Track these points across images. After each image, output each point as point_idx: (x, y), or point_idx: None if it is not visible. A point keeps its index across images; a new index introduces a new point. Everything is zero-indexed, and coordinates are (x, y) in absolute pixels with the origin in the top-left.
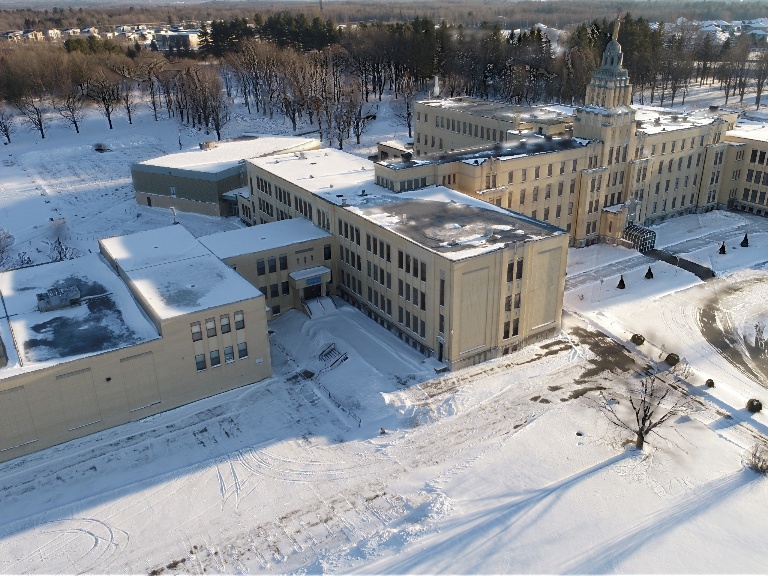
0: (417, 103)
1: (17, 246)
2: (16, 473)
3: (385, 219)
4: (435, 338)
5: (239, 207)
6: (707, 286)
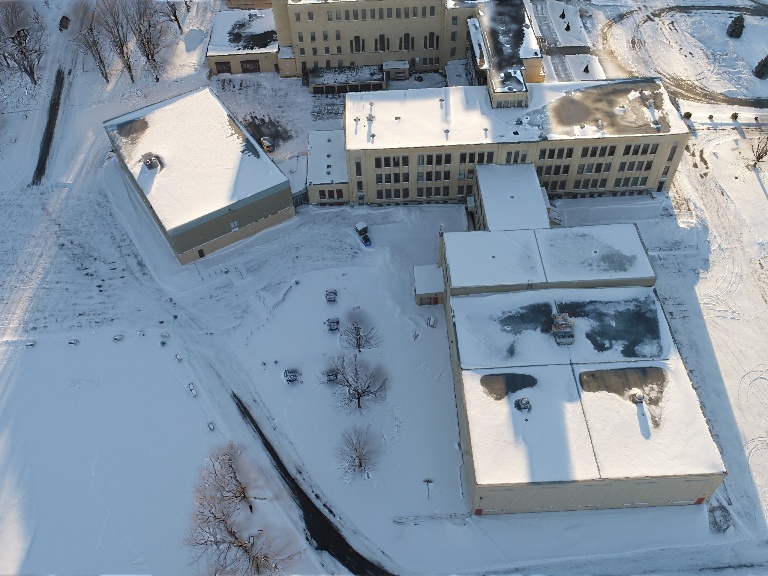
0: (295, 5)
1: (229, 382)
2: None
3: (589, 131)
4: (657, 181)
5: (312, 196)
6: (603, 59)
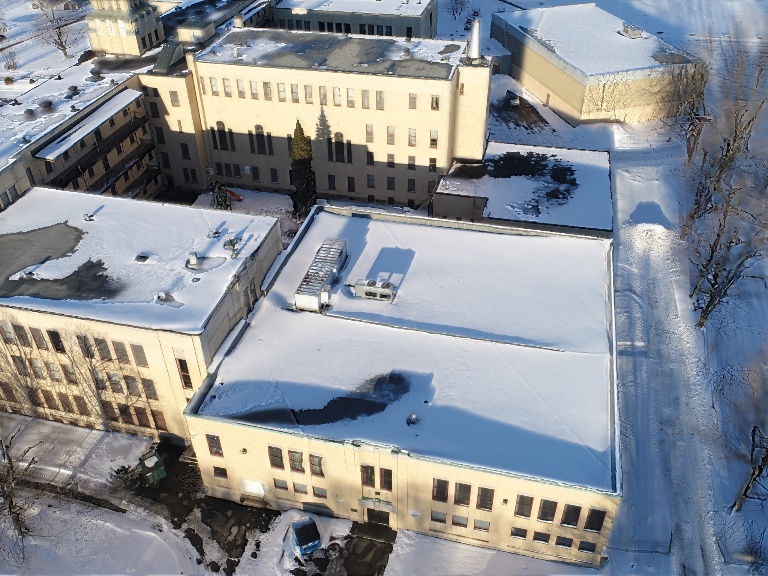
0: None
1: None
2: None
3: None
4: None
5: None
6: None
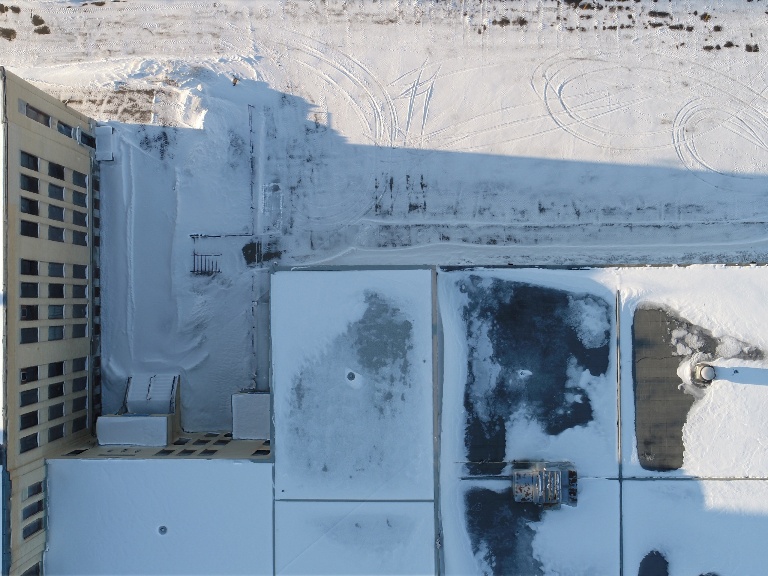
0: None
1: None
2: (619, 247)
3: None
4: None
5: None
6: None
